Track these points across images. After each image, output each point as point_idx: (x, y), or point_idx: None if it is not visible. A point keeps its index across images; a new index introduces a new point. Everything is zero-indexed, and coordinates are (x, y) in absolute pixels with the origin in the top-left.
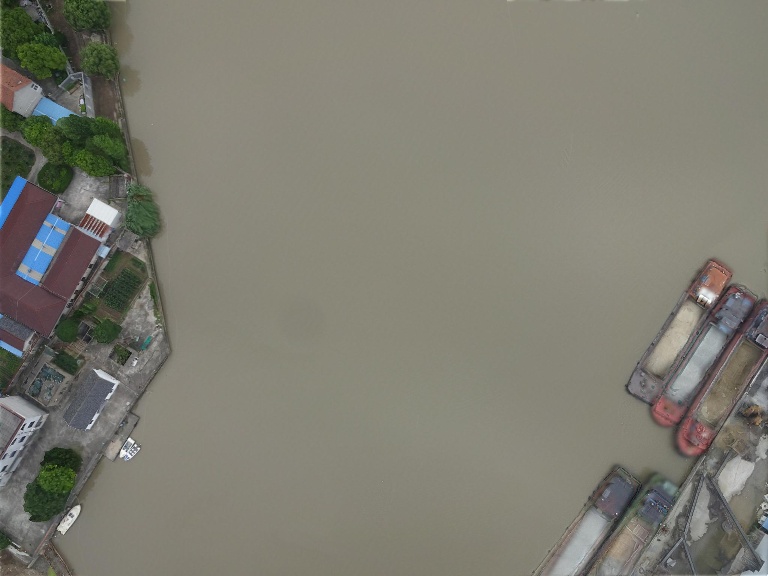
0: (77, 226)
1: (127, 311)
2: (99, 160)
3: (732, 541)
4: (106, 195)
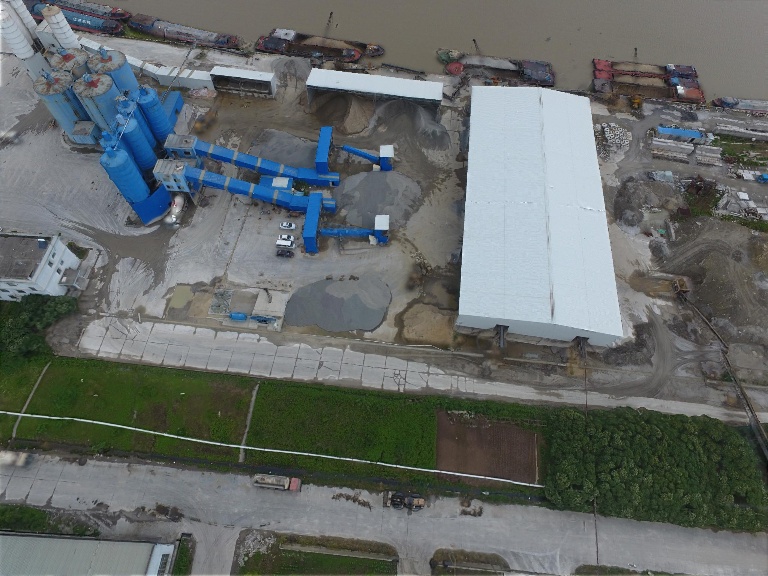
0: None
1: None
2: None
3: None
4: None
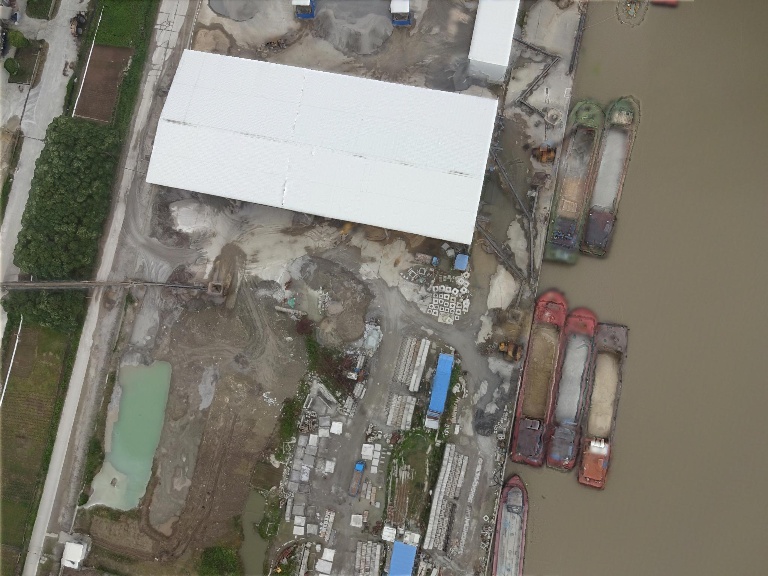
0: None
1: None
2: None
3: None
4: None
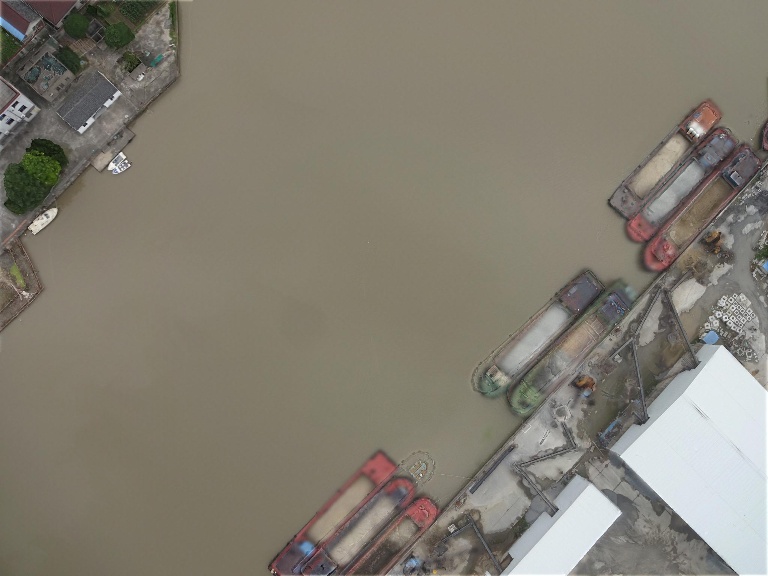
0: None
1: (142, 24)
2: None
3: (673, 351)
4: None
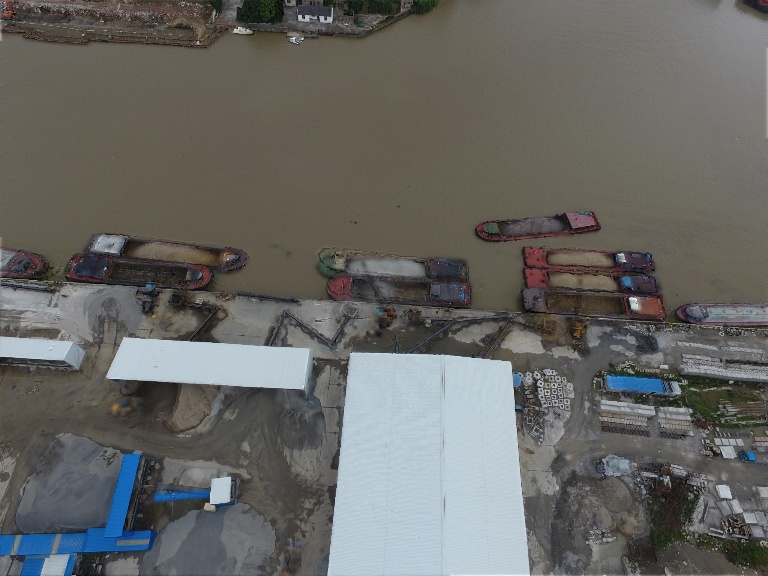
0: None
1: (371, 14)
2: None
3: None
4: None
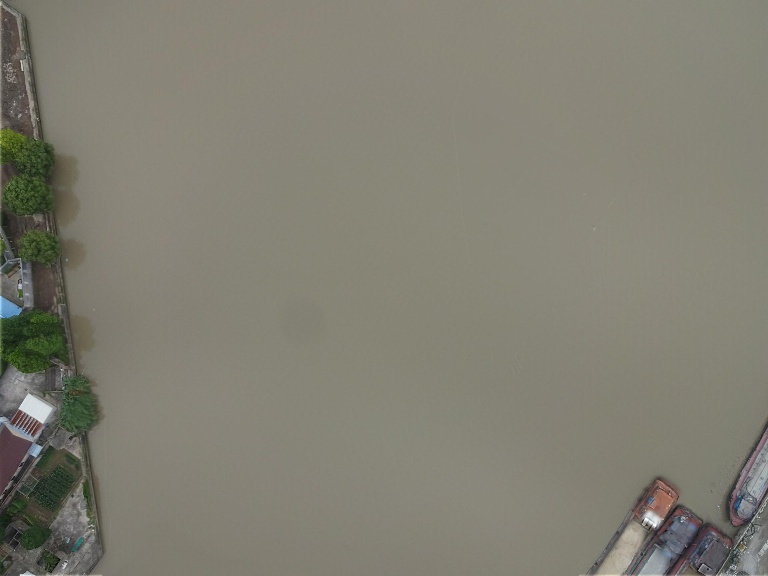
0: (8, 423)
1: (58, 510)
2: (33, 361)
3: None
4: (41, 387)
